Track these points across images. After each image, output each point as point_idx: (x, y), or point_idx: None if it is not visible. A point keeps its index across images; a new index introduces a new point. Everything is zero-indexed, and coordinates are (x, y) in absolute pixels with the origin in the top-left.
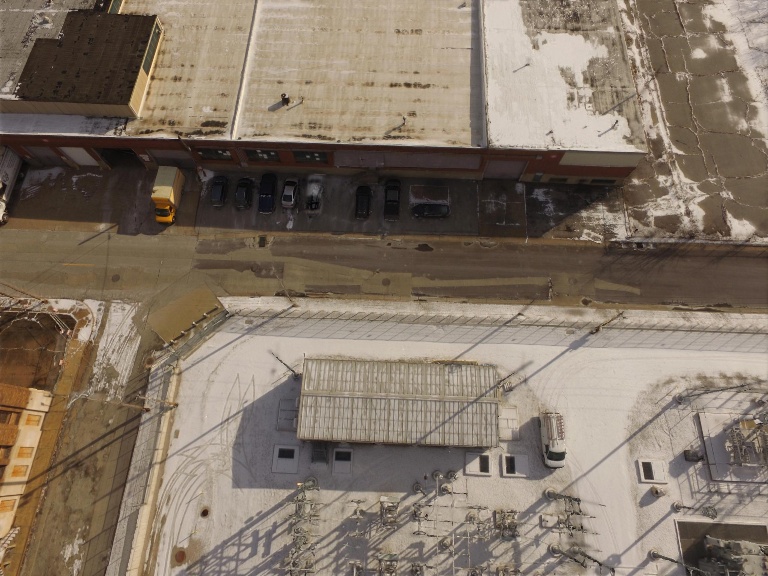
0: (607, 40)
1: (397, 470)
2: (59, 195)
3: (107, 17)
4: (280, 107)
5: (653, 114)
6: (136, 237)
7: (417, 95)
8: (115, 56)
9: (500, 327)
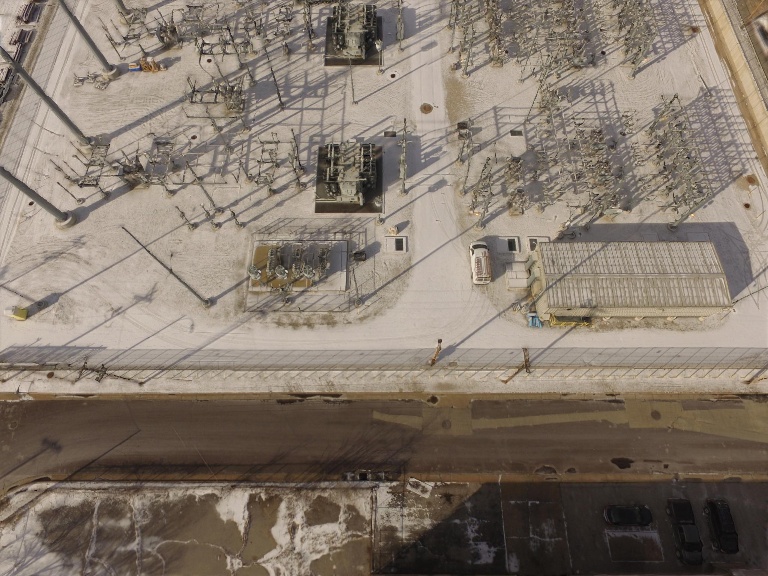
0: None
1: (605, 238)
2: None
3: None
4: None
5: None
6: None
7: None
8: None
9: None
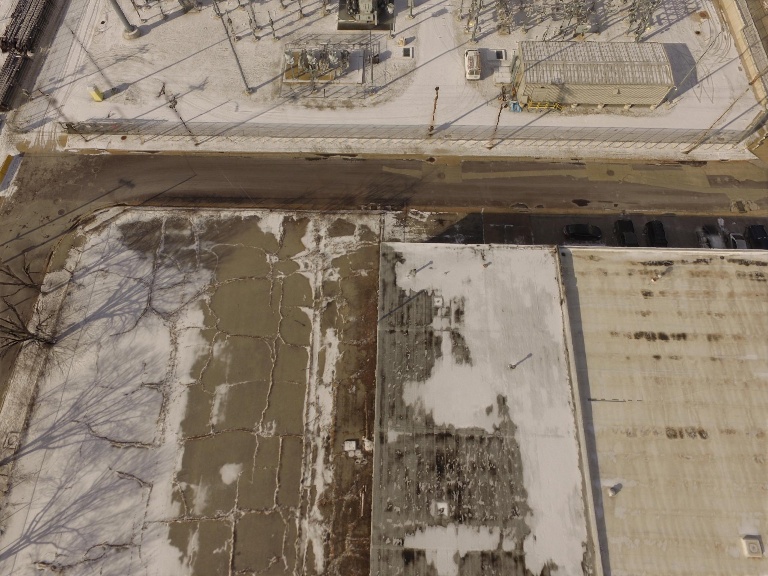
0: (401, 415)
1: None
2: None
3: None
4: None
5: (323, 365)
6: None
7: (648, 322)
8: None
9: (507, 138)
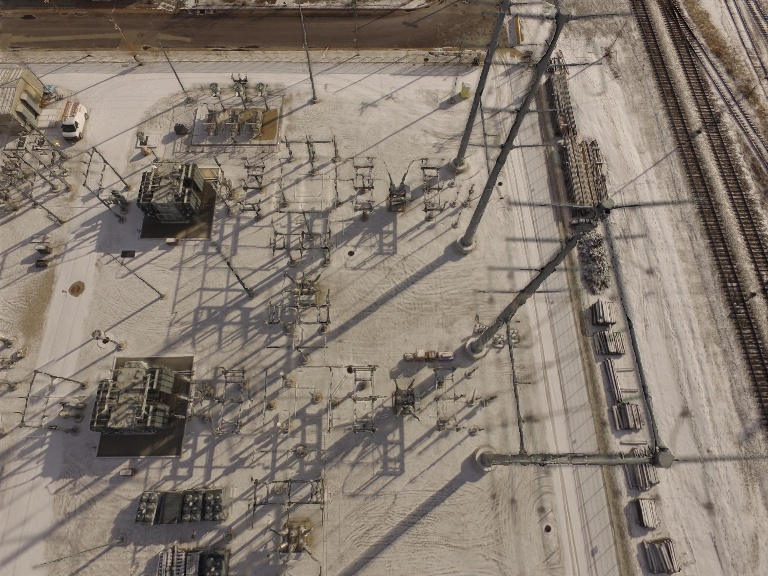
0: None
1: None
2: None
3: None
4: None
5: None
6: None
7: None
8: None
9: (70, 64)
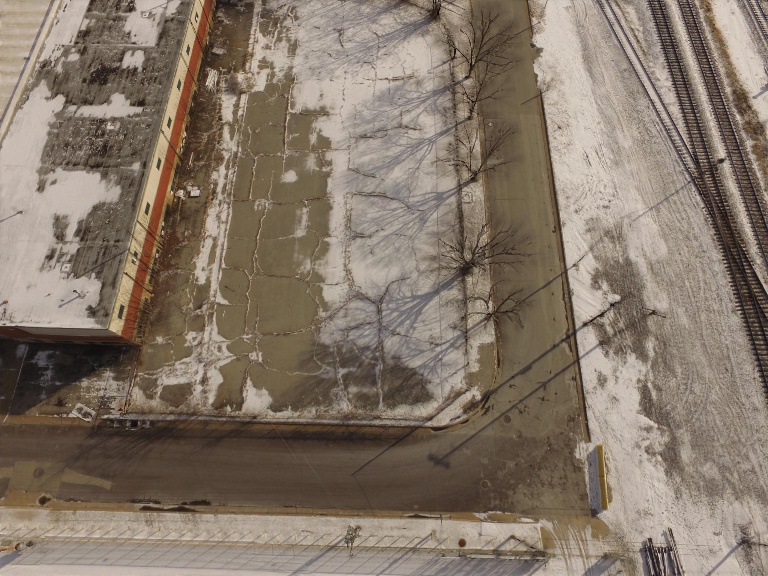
0: (125, 180)
1: None
2: None
3: None
4: None
5: (212, 253)
6: None
7: None
8: None
9: None
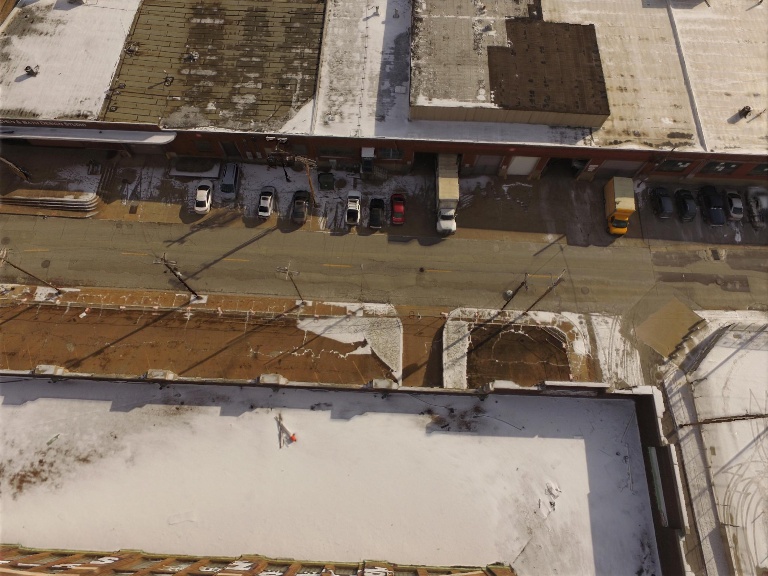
0: None
1: None
2: (495, 204)
3: (547, 25)
4: (739, 119)
5: None
6: (588, 248)
7: None
8: (573, 65)
9: None
